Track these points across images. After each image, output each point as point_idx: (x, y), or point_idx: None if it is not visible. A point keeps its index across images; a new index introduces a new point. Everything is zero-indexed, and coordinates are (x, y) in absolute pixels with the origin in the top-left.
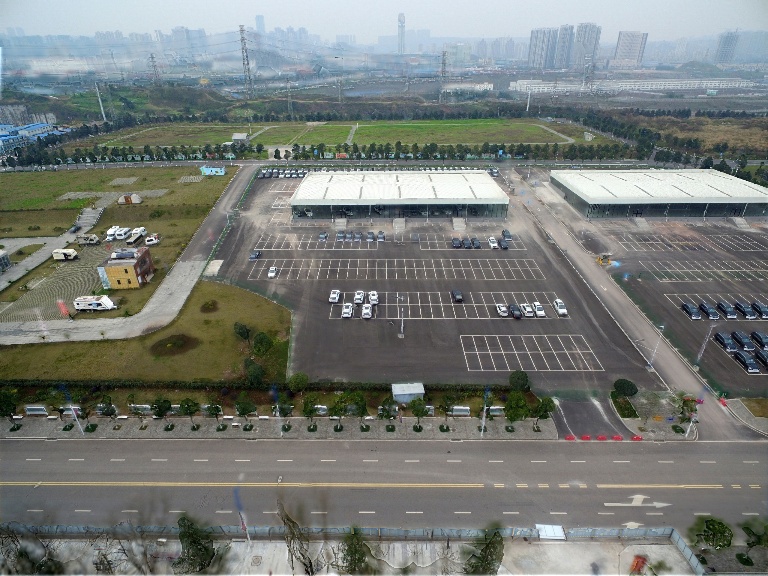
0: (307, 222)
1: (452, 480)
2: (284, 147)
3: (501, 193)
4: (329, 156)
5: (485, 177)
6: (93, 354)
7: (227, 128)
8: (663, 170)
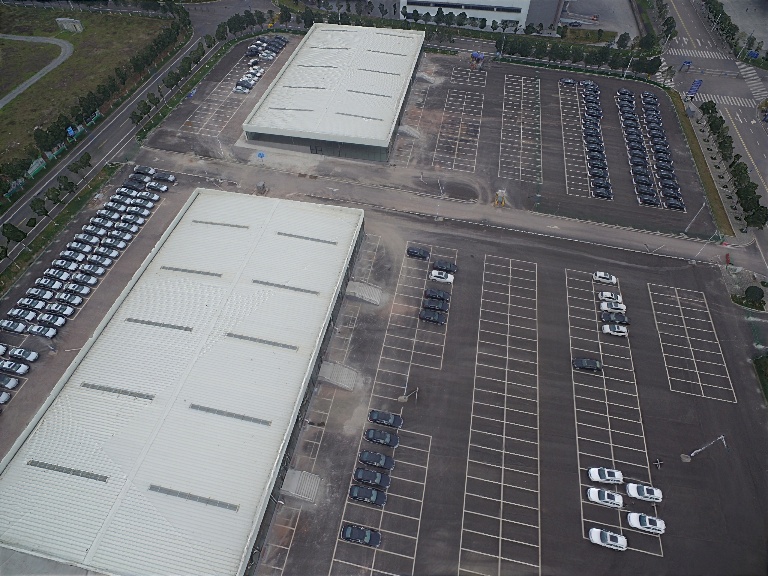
0: (260, 568)
1: None
2: None
3: (329, 210)
4: None
5: (232, 200)
6: None
7: None
8: (297, 49)
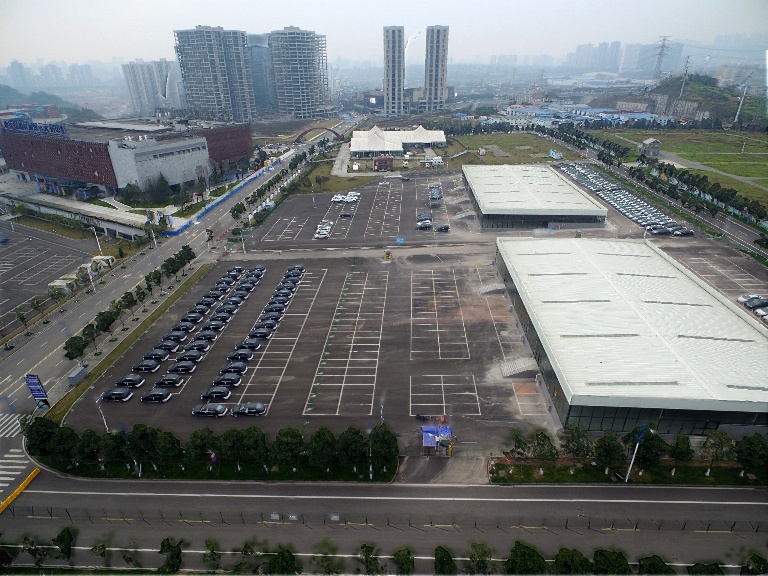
0: None
1: None
2: (681, 162)
3: None
4: (655, 174)
5: None
6: None
7: (763, 145)
8: (764, 328)
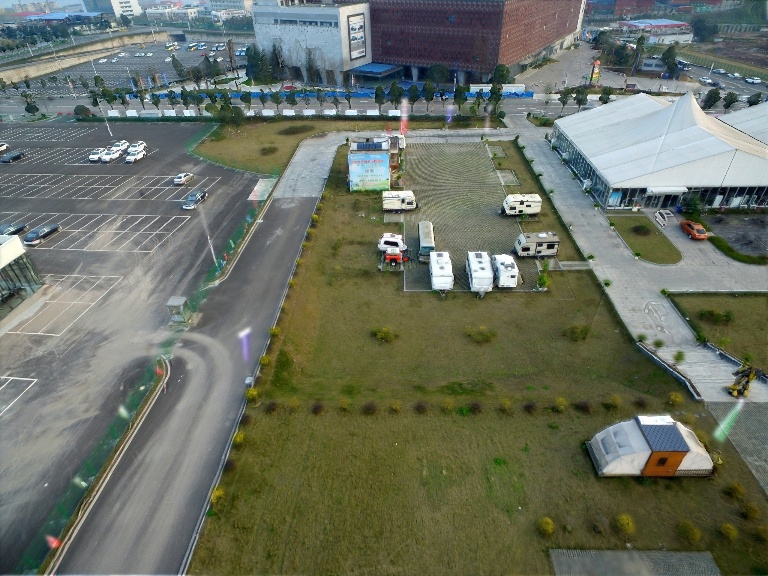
0: None
1: (164, 106)
2: None
3: None
4: None
5: None
6: (358, 127)
7: None
8: None
